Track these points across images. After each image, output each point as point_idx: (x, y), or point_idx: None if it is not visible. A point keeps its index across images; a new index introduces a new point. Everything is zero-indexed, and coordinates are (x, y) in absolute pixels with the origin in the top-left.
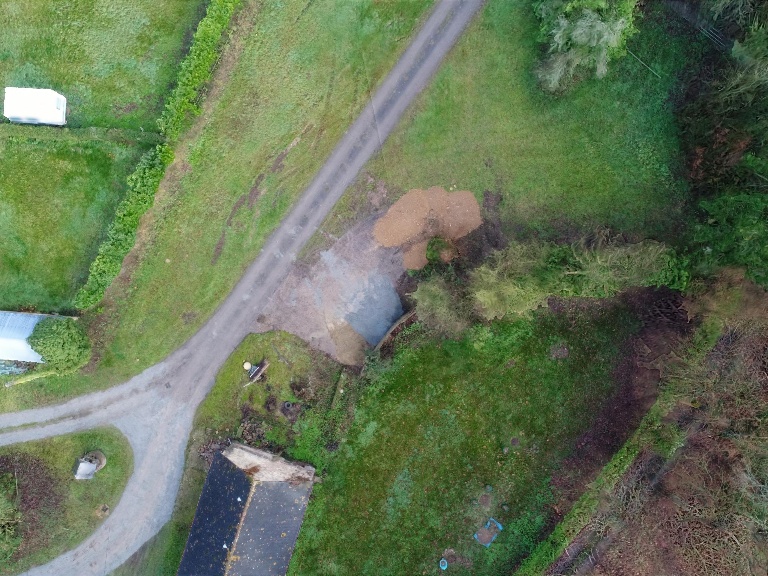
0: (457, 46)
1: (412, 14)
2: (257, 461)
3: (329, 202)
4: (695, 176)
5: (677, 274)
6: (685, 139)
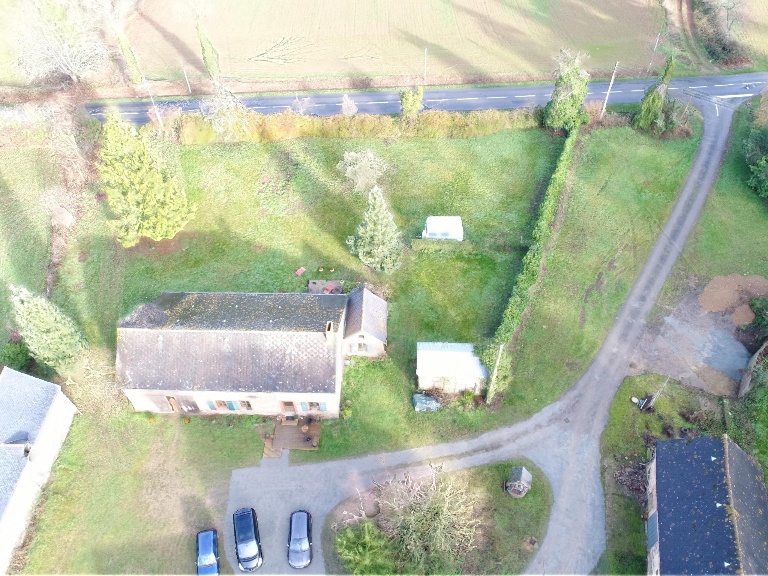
0: (707, 203)
1: (670, 190)
2: None
3: (657, 286)
4: None
5: None
6: None
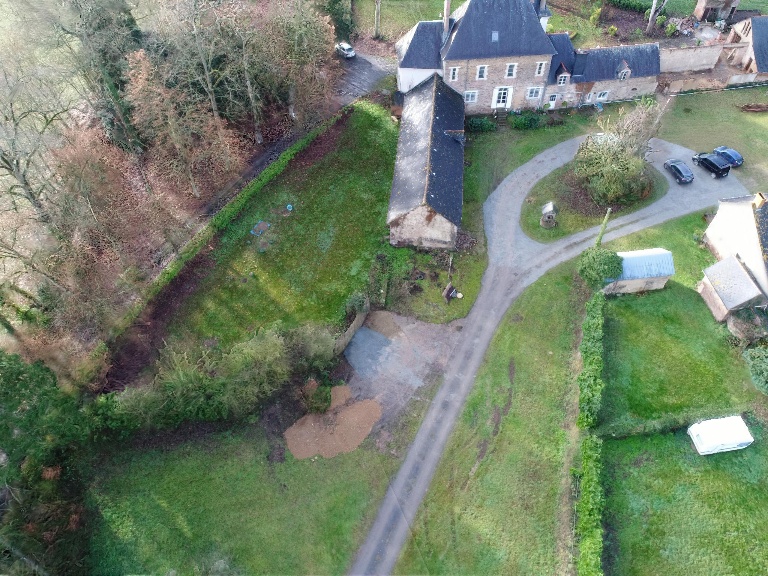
0: None
1: None
2: (431, 231)
3: (427, 425)
4: (78, 507)
5: (109, 401)
6: (82, 553)
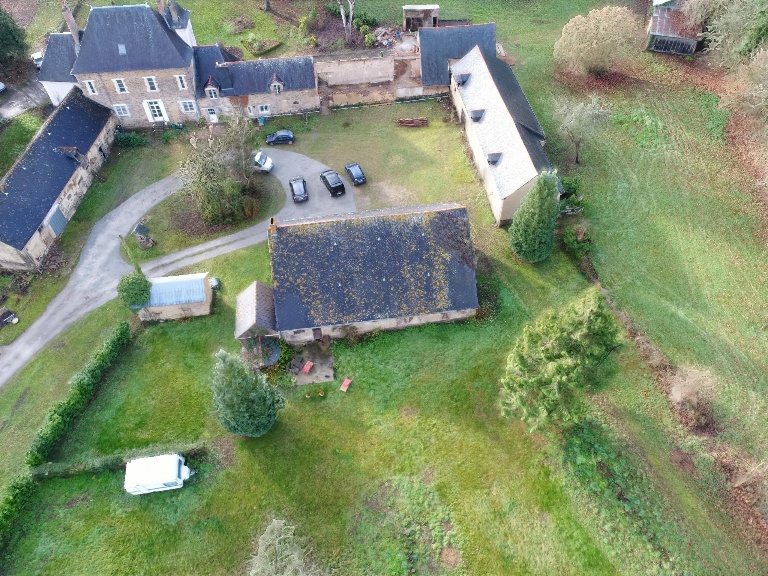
0: None
1: None
2: None
3: None
4: None
5: None
6: None
